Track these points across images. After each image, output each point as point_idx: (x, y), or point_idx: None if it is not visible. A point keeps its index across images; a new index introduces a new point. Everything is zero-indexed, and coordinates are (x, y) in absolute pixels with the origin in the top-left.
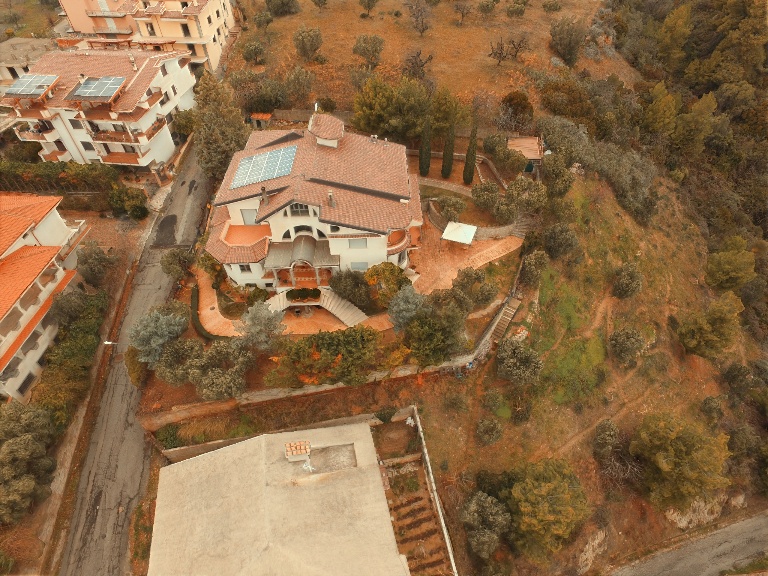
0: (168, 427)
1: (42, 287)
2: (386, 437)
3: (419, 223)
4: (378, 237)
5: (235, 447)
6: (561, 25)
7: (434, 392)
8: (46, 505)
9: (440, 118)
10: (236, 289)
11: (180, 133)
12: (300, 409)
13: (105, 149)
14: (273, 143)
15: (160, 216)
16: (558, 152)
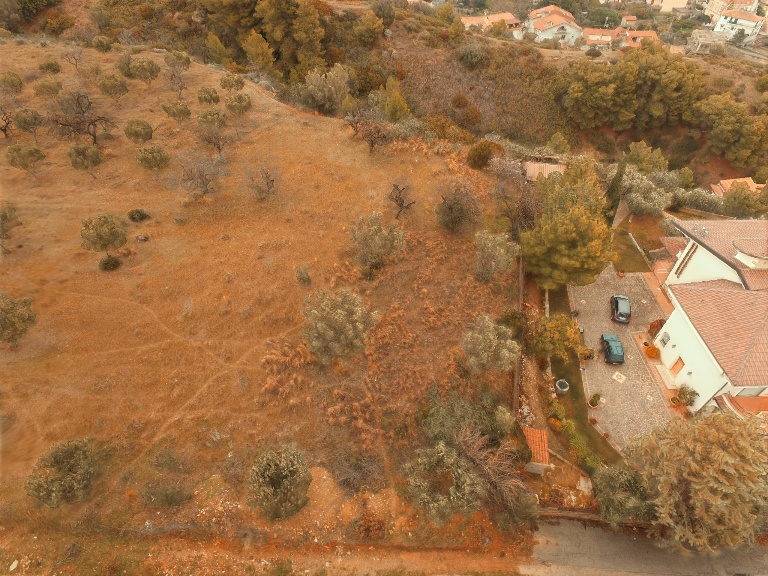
0: None
1: None
2: None
3: None
4: None
5: None
6: (328, 84)
7: None
8: None
9: None
10: None
11: None
12: None
13: None
14: None
15: None
16: None
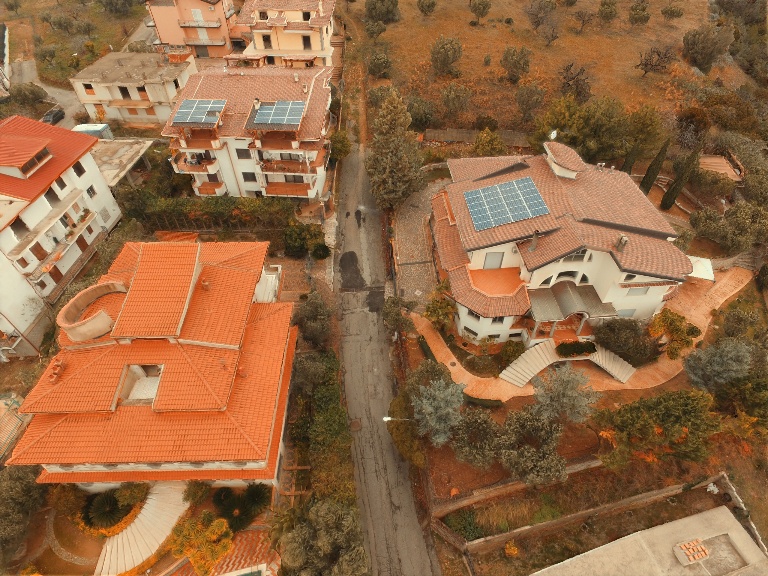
0: (462, 513)
1: None
2: (694, 509)
3: None
4: (675, 285)
5: (608, 549)
6: (703, 33)
7: (740, 455)
8: None
9: (640, 139)
10: (482, 342)
11: (332, 158)
12: (606, 484)
13: (265, 179)
14: (495, 174)
15: (337, 253)
16: (754, 172)
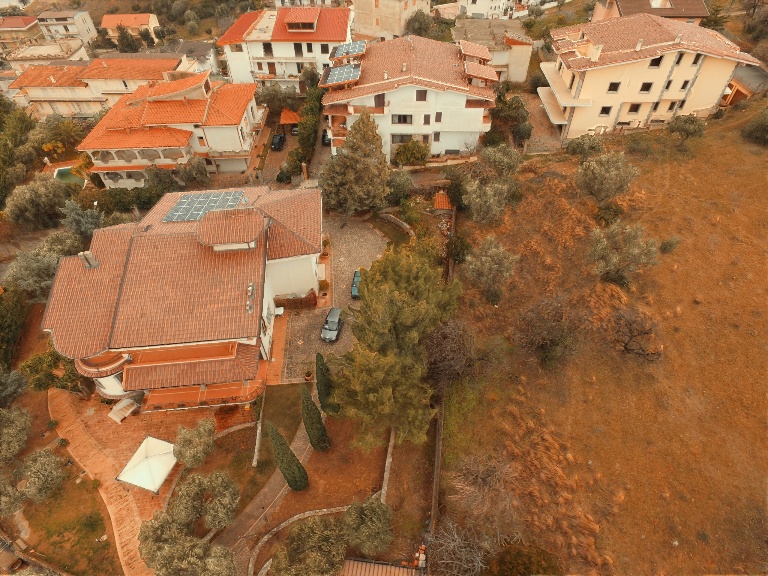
0: None
1: (162, 157)
2: None
3: (123, 385)
4: None
5: None
6: None
7: None
8: (41, 235)
9: None
10: None
11: None
12: None
13: None
14: None
15: None
16: None
